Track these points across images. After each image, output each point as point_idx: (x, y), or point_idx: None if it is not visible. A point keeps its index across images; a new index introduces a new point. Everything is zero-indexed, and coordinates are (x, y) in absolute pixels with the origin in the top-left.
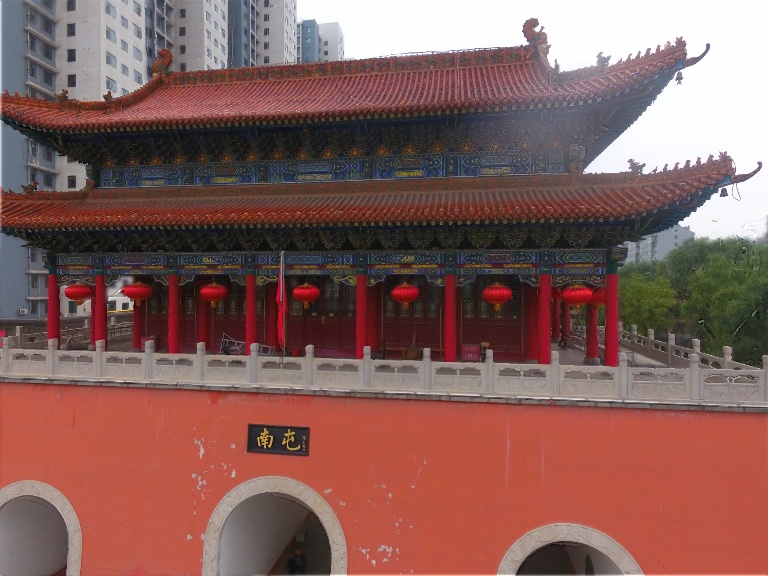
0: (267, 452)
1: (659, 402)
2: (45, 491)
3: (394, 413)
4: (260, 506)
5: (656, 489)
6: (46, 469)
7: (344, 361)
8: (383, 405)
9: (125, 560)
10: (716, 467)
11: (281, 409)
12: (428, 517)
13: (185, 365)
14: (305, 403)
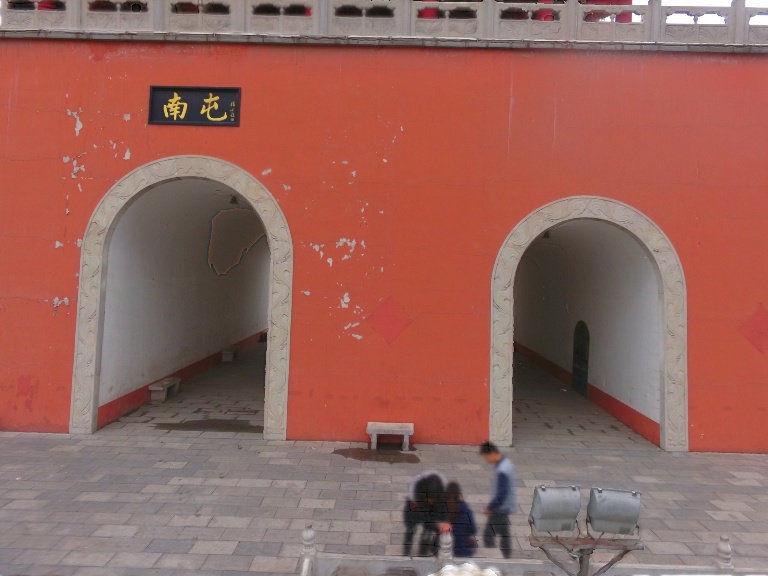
0: (178, 123)
1: (699, 43)
2: None
3: (360, 66)
4: (171, 267)
5: (692, 150)
6: None
7: None
8: (345, 56)
9: None
10: (762, 120)
11: (199, 64)
12: (405, 199)
13: (54, 10)
14: (234, 56)
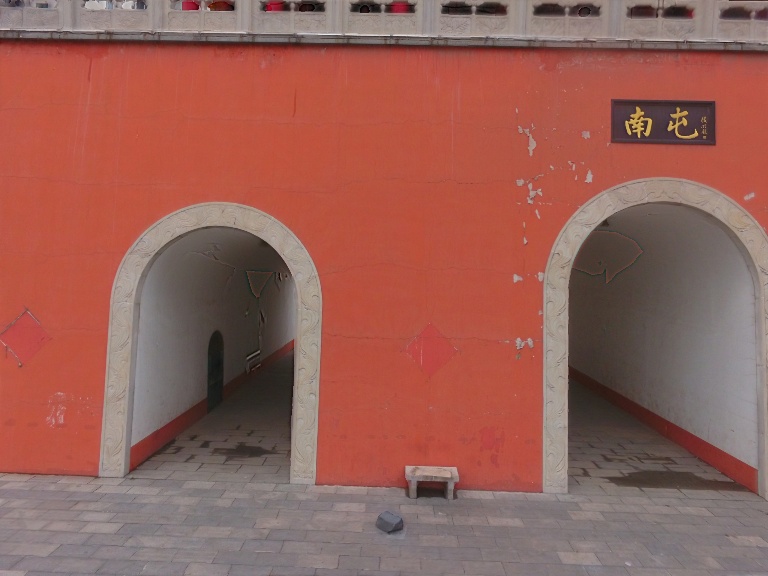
0: (646, 141)
1: None
2: (247, 218)
3: None
4: None
5: None
6: (246, 183)
7: (766, 2)
8: None
9: (403, 321)
10: None
11: (666, 75)
12: None
13: (492, 15)
14: (706, 65)
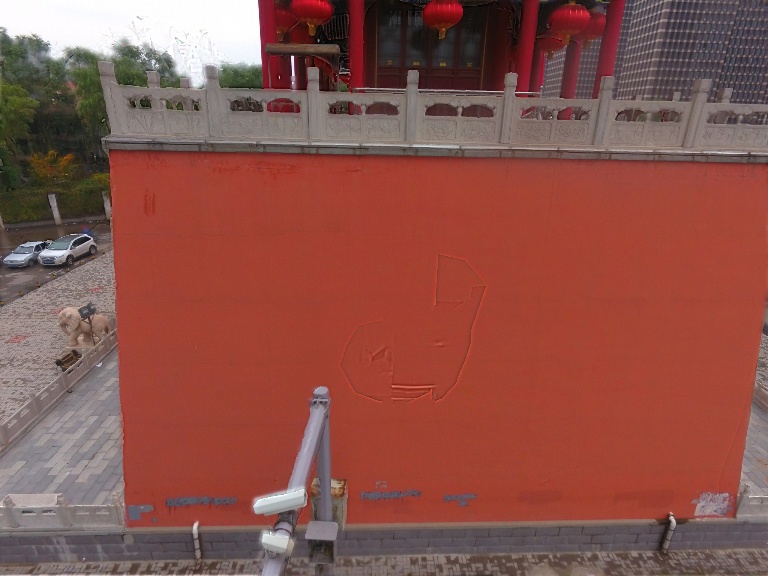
0: None
1: None
2: None
3: None
4: None
5: None
6: None
7: None
8: None
9: None
10: None
11: None
12: None
13: None
14: None
